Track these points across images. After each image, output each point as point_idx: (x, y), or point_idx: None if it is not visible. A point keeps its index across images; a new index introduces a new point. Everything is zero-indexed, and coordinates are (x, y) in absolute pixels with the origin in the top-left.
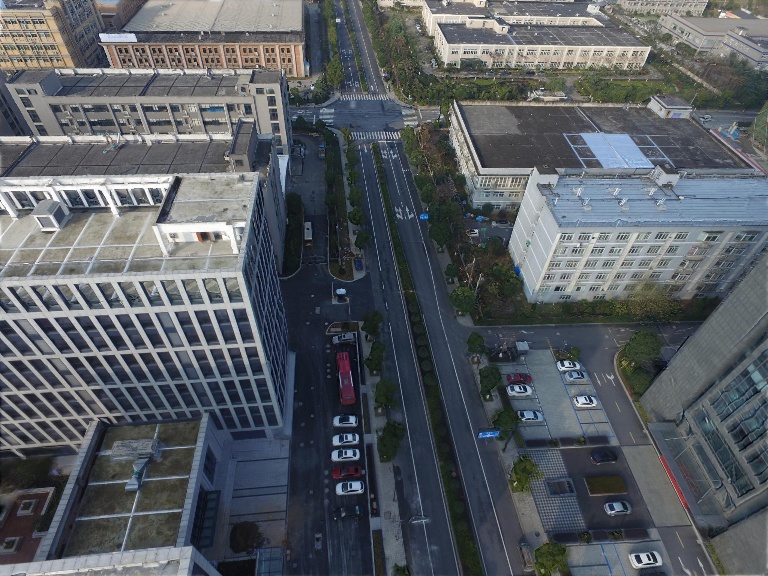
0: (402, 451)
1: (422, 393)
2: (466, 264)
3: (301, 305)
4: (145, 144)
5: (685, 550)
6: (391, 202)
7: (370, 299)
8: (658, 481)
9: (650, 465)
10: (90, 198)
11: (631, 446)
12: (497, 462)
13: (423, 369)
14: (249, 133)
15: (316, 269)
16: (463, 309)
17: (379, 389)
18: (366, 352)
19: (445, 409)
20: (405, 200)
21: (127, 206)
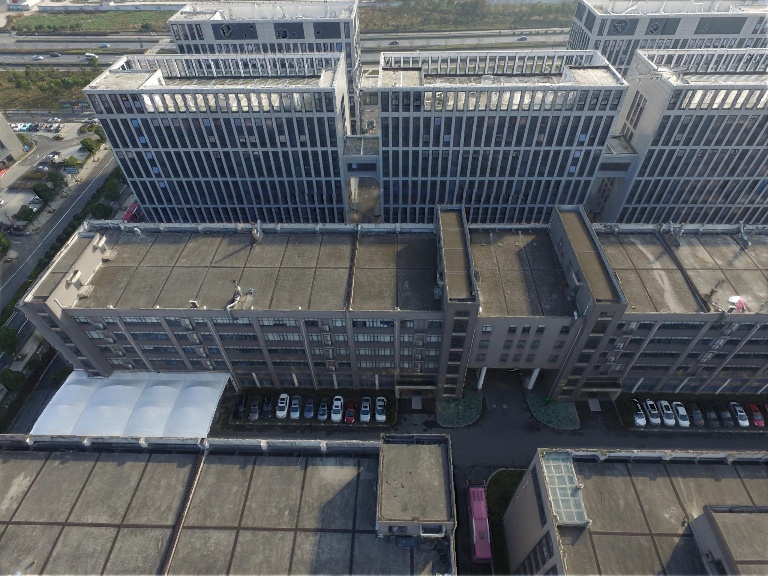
0: (124, 194)
1: (90, 215)
2: None
3: None
4: None
5: (30, 160)
6: None
7: None
8: (8, 176)
9: (2, 181)
10: None
11: (0, 187)
12: None
13: None
14: (52, 273)
15: None
16: (8, 239)
17: (112, 180)
18: None
19: None
20: None
21: None
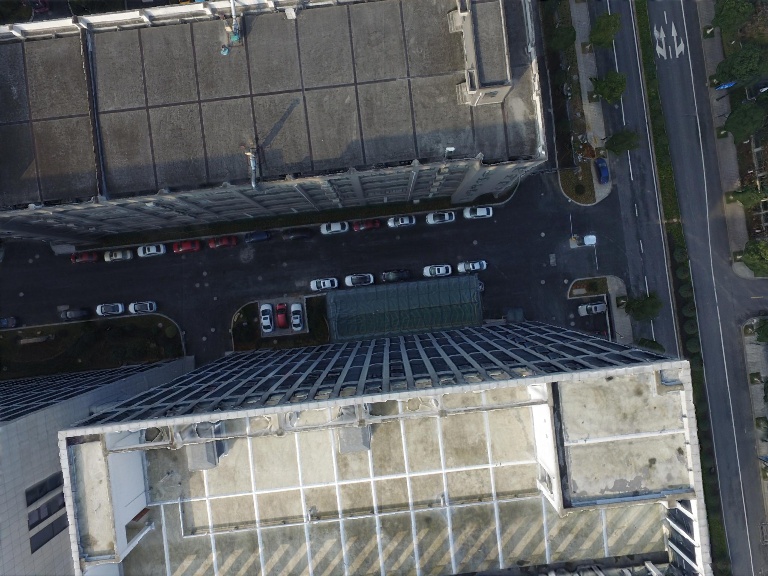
0: None
1: None
2: (762, 168)
3: (530, 252)
4: (282, 14)
5: None
6: (648, 13)
7: (619, 236)
8: None
9: None
10: (261, 190)
11: None
12: (754, 451)
13: (689, 350)
14: None
15: (541, 183)
16: (759, 273)
17: None
18: (618, 324)
19: (707, 395)
20: (671, 5)
21: (444, 380)
